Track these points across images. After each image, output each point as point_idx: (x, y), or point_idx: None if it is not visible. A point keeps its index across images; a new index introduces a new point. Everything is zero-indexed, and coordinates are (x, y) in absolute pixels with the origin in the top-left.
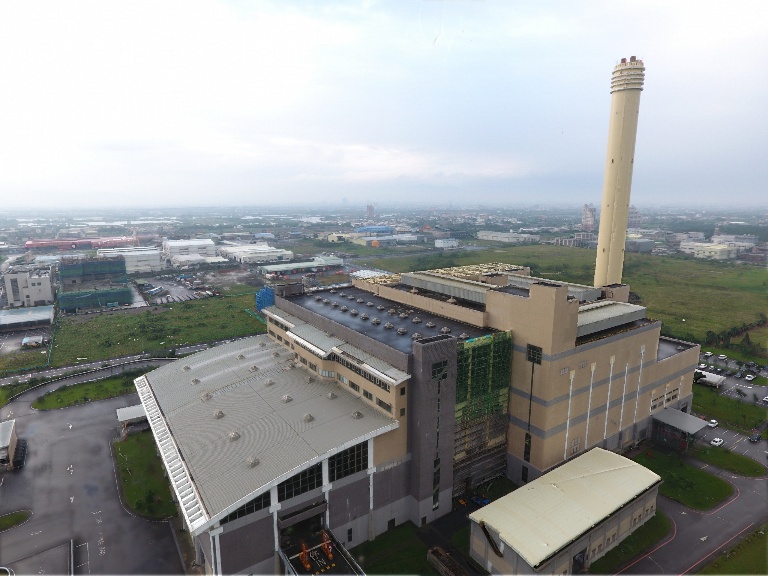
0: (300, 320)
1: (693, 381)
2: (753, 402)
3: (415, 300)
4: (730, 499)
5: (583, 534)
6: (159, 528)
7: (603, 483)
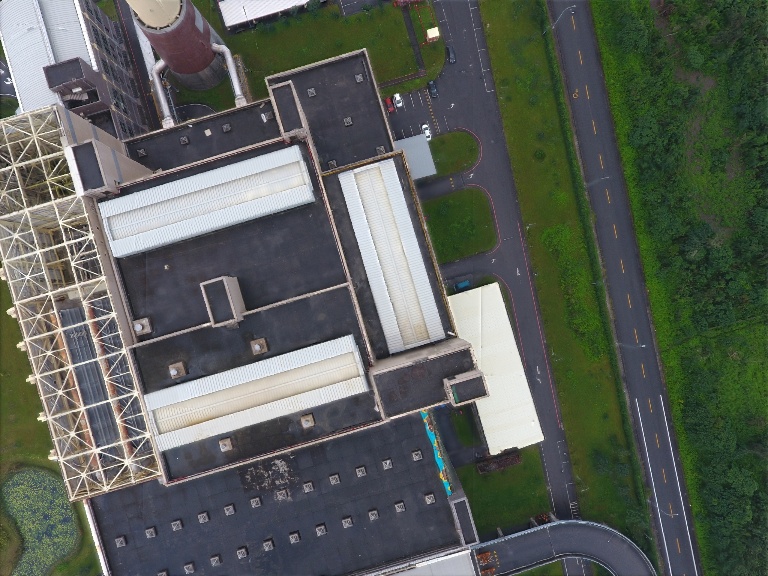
0: None
1: (306, 9)
2: (373, 1)
3: None
4: (492, 209)
5: (530, 389)
6: None
7: (494, 337)
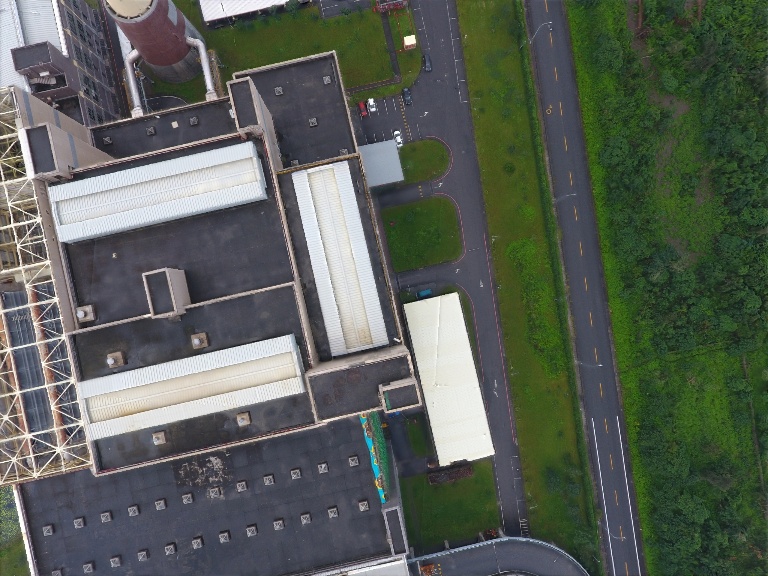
0: None
1: None
2: (353, 5)
3: None
4: (459, 219)
5: (484, 402)
6: None
7: (450, 347)
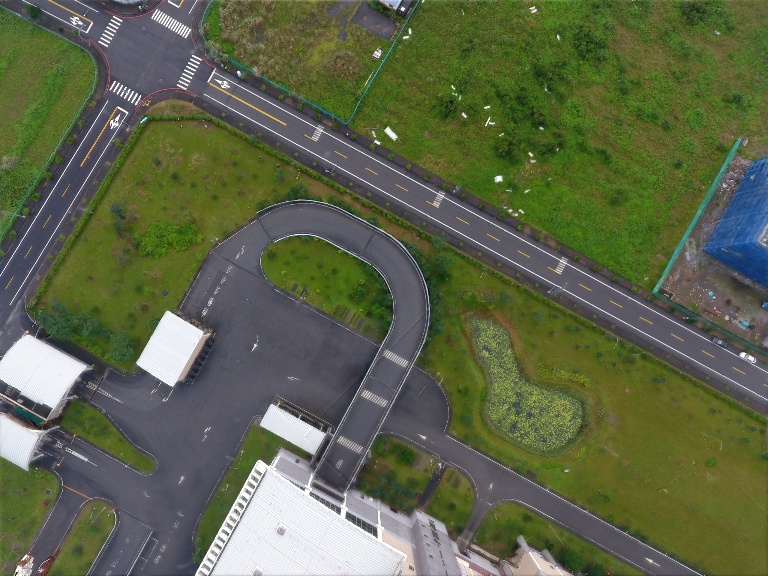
0: None
1: None
2: None
3: None
4: None
5: None
6: (192, 575)
7: None
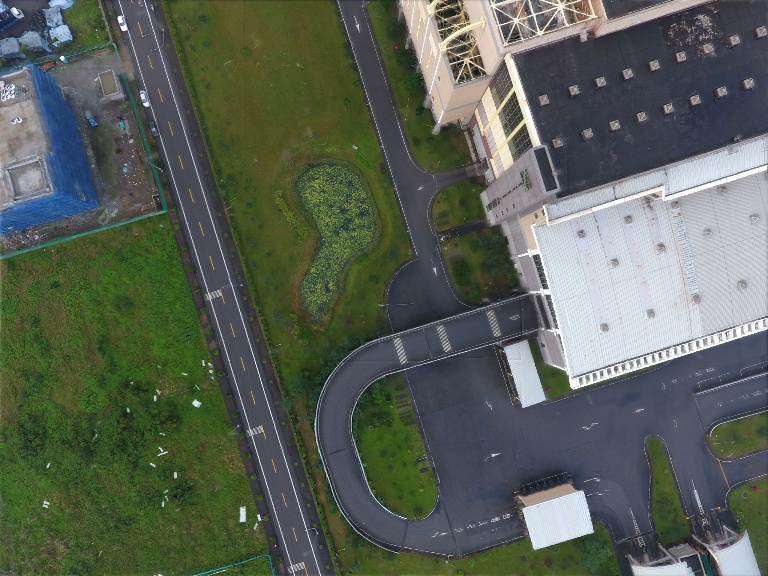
0: (649, 176)
1: None
2: None
3: None
4: None
5: None
6: None
7: None
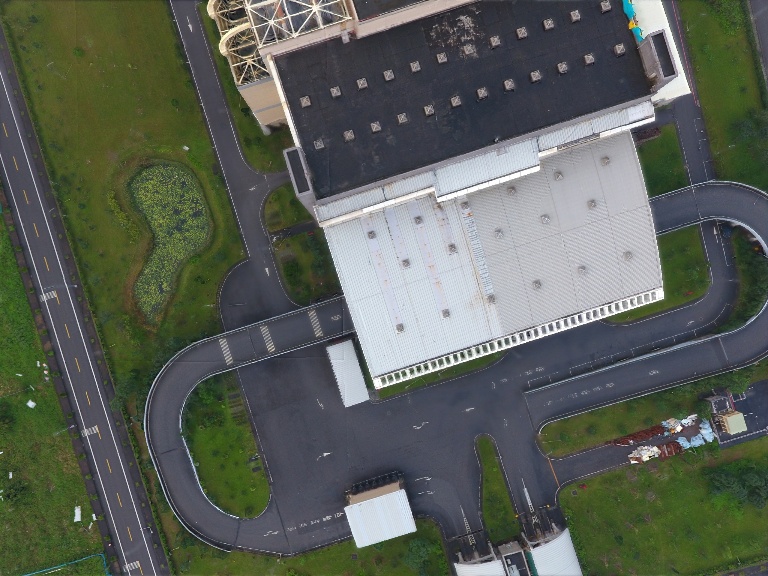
0: (418, 177)
1: None
2: None
3: (453, 0)
4: None
5: (675, 43)
6: None
7: None
